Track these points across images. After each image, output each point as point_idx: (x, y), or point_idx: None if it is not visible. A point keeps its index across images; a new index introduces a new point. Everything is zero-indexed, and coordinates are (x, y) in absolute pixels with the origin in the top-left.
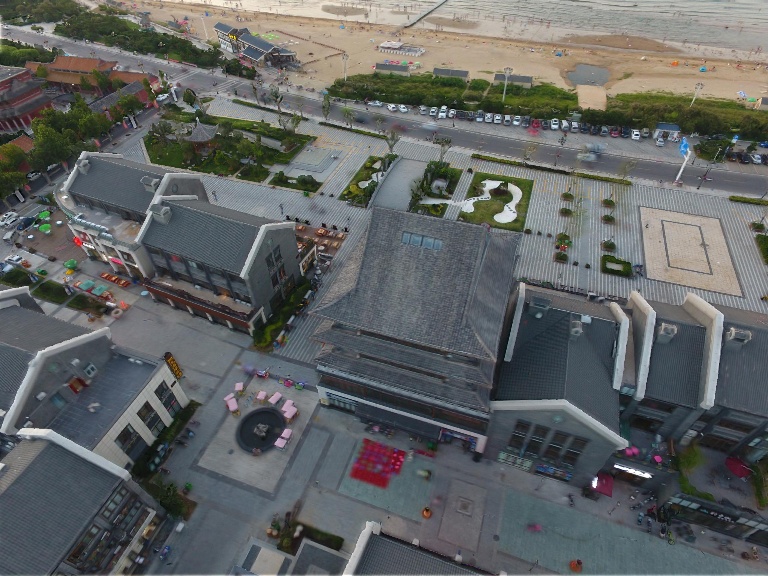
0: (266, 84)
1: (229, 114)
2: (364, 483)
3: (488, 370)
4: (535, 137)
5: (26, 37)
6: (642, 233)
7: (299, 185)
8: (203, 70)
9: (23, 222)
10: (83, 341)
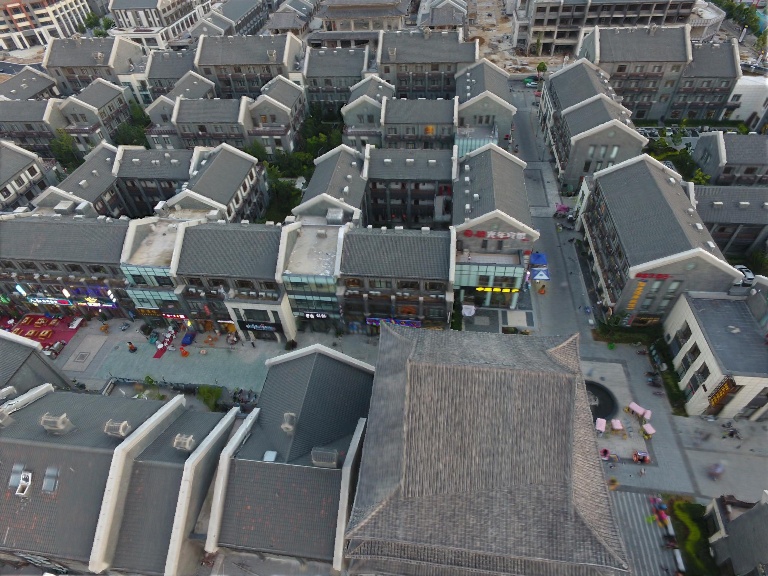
0: None
1: None
2: None
3: None
4: None
5: None
6: None
7: None
8: None
9: None
10: None
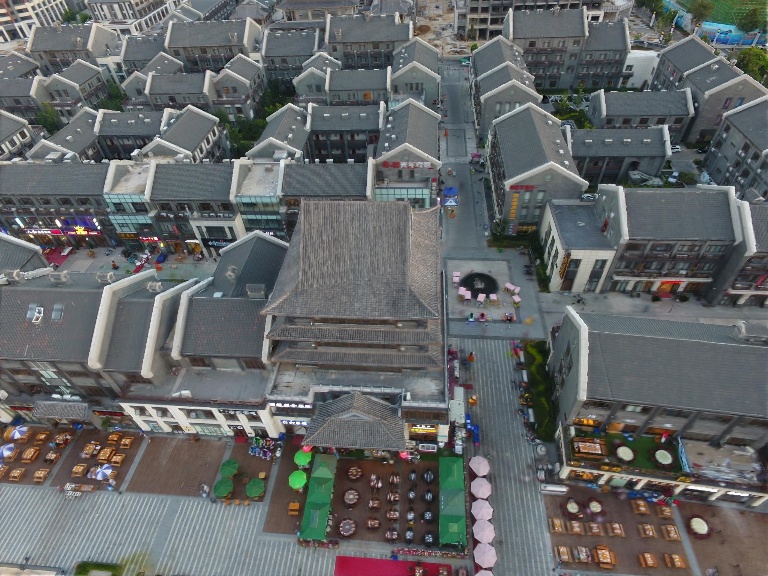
0: None
1: None
2: None
3: None
4: None
5: None
6: None
7: None
8: None
9: None
10: None
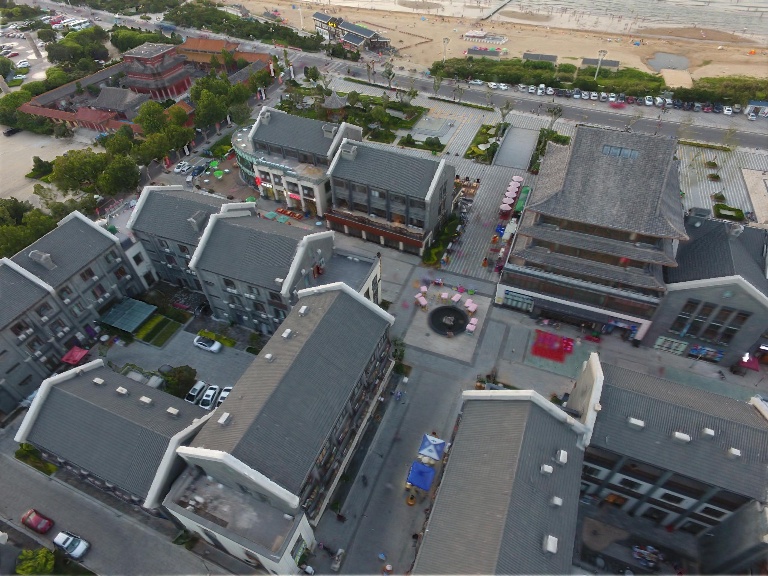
0: (370, 65)
1: (344, 89)
2: (544, 359)
3: (670, 255)
4: (632, 111)
5: (138, 25)
6: (747, 189)
7: (426, 146)
8: (308, 53)
9: (197, 169)
10: (323, 236)
